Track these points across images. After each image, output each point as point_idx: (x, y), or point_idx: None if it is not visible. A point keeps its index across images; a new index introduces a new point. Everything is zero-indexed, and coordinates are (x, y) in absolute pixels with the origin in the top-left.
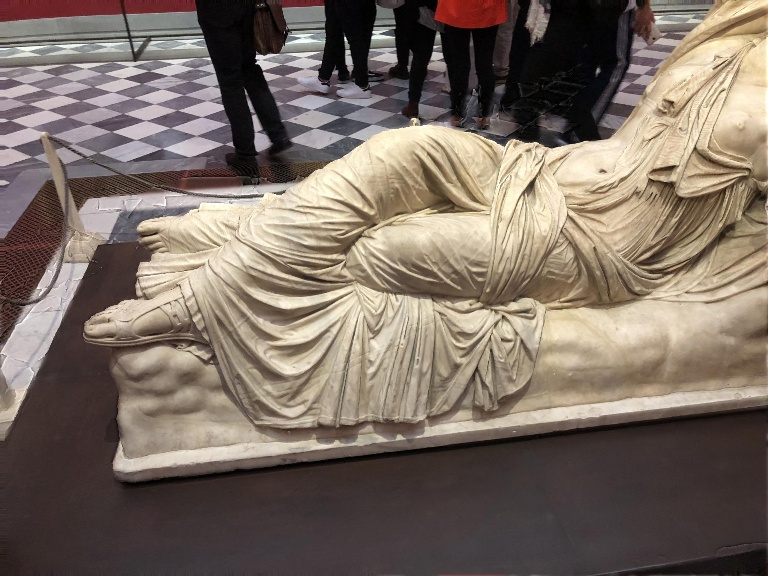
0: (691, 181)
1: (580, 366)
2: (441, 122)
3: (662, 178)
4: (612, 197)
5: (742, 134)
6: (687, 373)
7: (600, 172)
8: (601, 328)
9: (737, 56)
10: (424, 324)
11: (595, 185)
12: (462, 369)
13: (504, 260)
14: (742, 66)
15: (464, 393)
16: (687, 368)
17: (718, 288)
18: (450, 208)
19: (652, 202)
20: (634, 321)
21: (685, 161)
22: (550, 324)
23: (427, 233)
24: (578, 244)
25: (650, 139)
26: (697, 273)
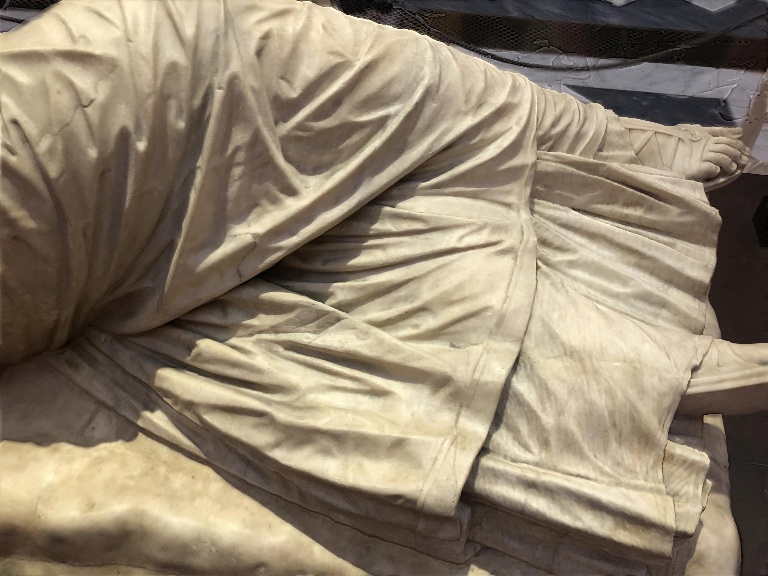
0: None
1: None
2: None
3: None
4: None
5: None
6: None
7: None
8: None
9: None
10: None
11: None
12: None
13: None
14: None
15: None
16: None
17: None
18: None
19: None
20: None
21: None
22: None
23: None
24: None
25: None
26: None
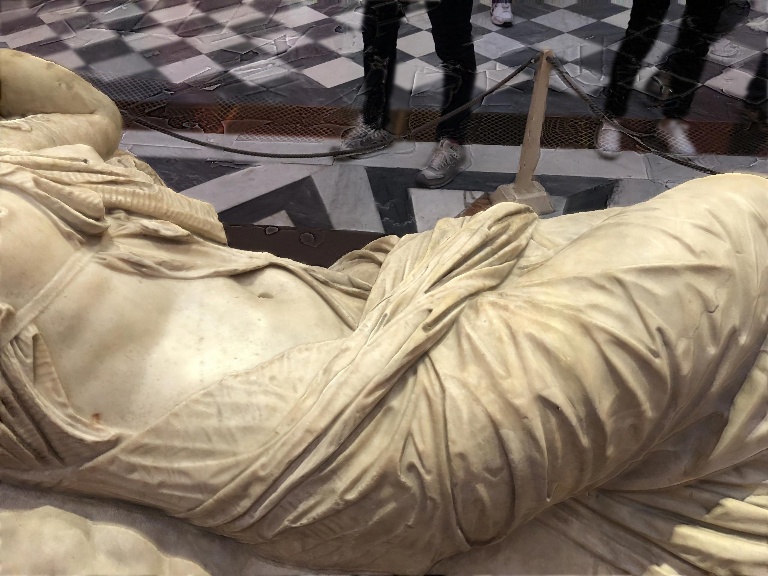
0: None
1: None
2: None
3: None
4: None
5: None
6: None
7: None
8: None
9: None
10: None
11: None
12: None
13: None
14: None
15: None
16: None
17: None
18: None
19: None
20: None
21: None
22: None
23: None
24: None
25: None
26: None
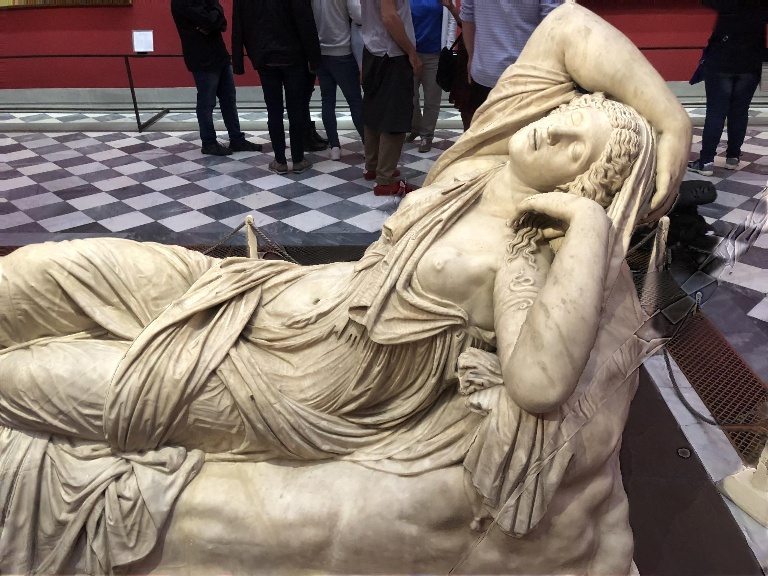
0: (391, 325)
1: (223, 538)
2: (382, 211)
3: (357, 319)
4: (310, 334)
5: (441, 276)
6: (361, 563)
7: (316, 302)
8: (261, 493)
9: (481, 180)
10: (23, 470)
11: (291, 319)
12: (68, 527)
13: (117, 405)
14: (485, 192)
15: (75, 555)
16: (360, 557)
17: (418, 459)
18: (105, 334)
19: (353, 345)
20: (306, 489)
21: (378, 302)
22: (200, 481)
23: (30, 366)
24: (232, 390)
25: (360, 270)
26: (415, 434)
